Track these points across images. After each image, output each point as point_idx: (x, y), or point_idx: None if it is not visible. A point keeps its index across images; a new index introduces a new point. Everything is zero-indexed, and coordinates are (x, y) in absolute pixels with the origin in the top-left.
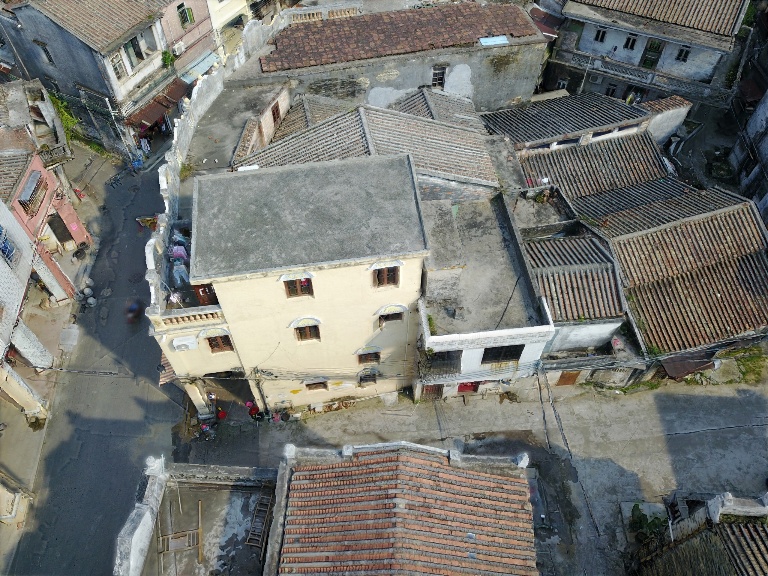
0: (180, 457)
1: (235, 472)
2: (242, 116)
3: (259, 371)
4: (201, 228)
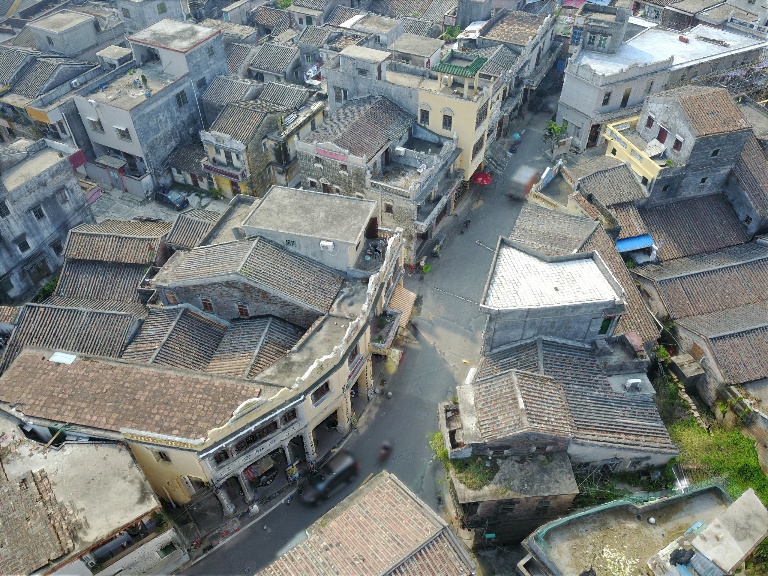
0: (419, 302)
1: (386, 183)
2: (300, 358)
3: None
4: (363, 221)
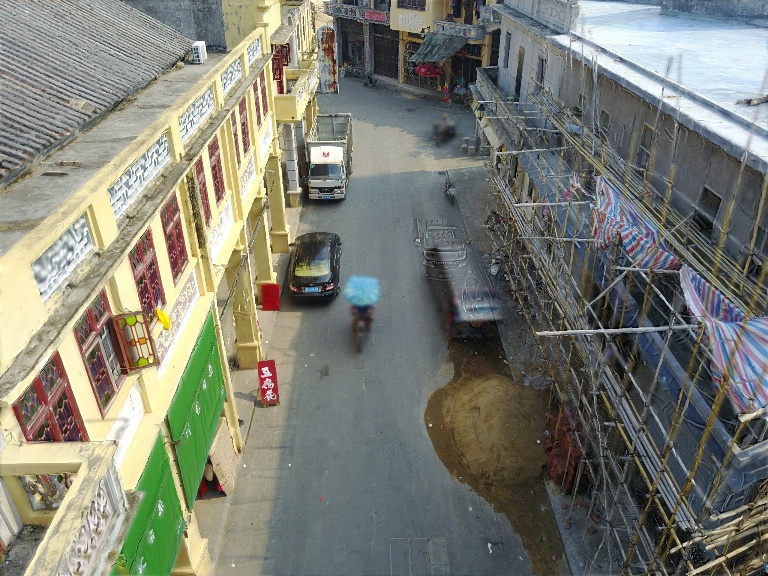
0: None
1: None
2: None
3: (315, 8)
4: None
